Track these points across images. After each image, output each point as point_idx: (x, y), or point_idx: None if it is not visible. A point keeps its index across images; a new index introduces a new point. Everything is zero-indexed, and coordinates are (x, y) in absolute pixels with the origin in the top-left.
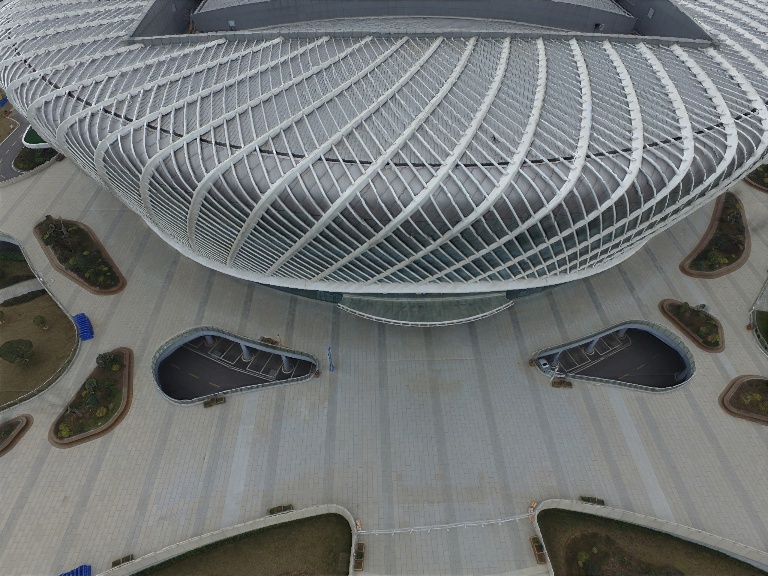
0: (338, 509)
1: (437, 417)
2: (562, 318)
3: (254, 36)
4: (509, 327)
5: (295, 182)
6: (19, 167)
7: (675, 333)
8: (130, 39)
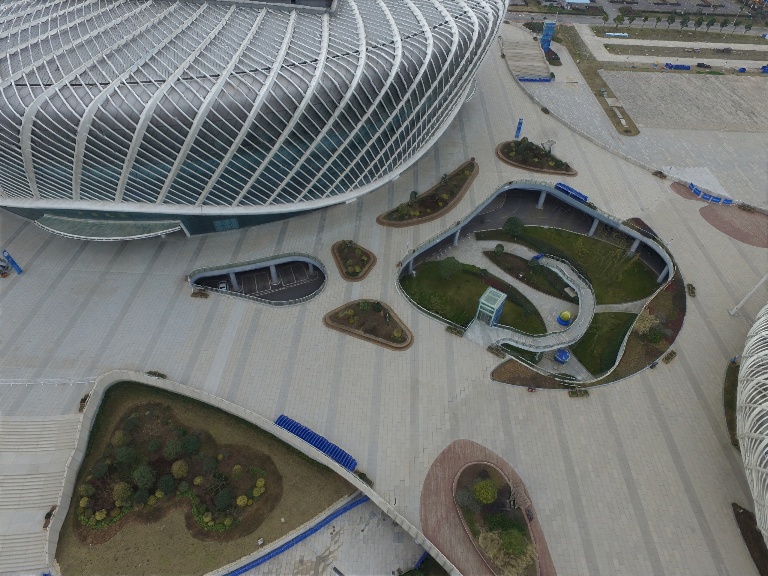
0: None
1: (79, 311)
2: (241, 249)
3: None
4: (190, 252)
5: None
6: None
7: (329, 265)
8: None
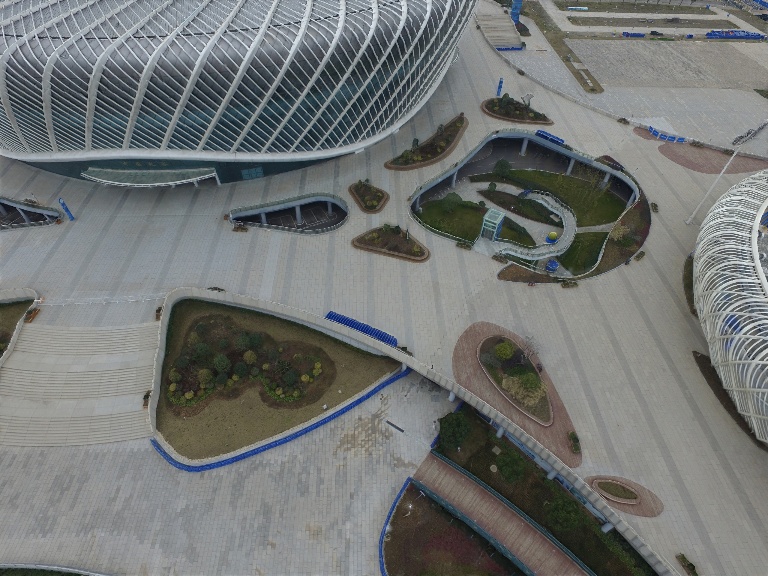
0: (31, 292)
1: (135, 247)
2: (269, 193)
3: None
4: (224, 197)
5: None
6: None
7: (349, 202)
8: None
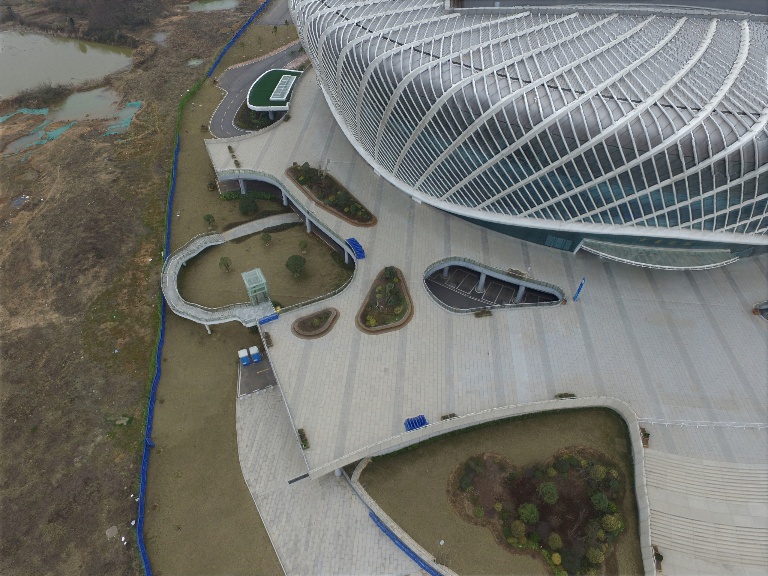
0: (615, 402)
1: (680, 345)
2: None
3: (554, 11)
4: (726, 282)
5: (635, 121)
6: (240, 126)
7: None
8: (451, 9)
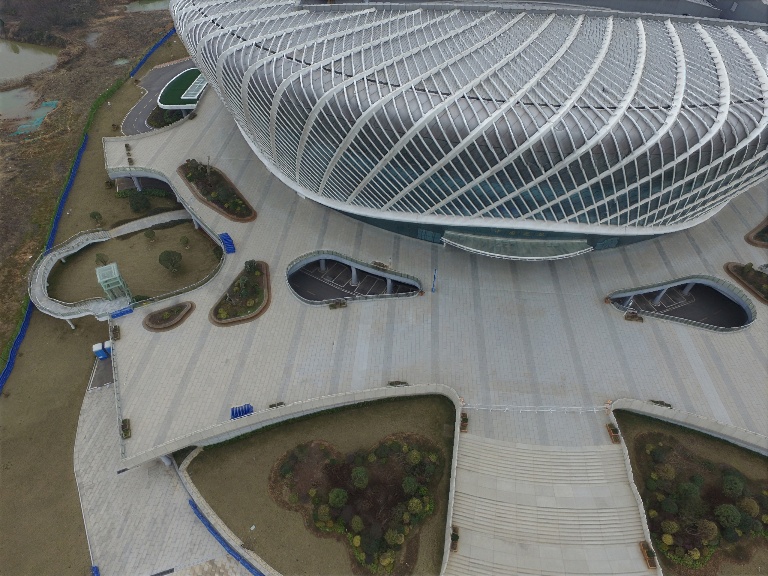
0: (445, 389)
1: (524, 333)
2: (634, 269)
3: (399, 7)
4: (586, 272)
5: (443, 113)
6: (152, 125)
7: (738, 289)
8: (300, 6)
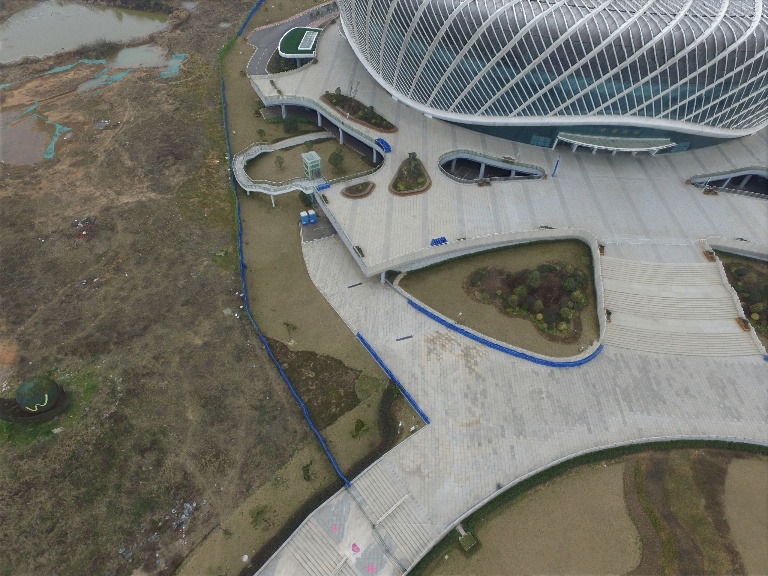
0: (581, 231)
1: (630, 201)
2: (704, 164)
3: None
4: (668, 166)
5: (590, 21)
6: (273, 72)
7: None
8: None
